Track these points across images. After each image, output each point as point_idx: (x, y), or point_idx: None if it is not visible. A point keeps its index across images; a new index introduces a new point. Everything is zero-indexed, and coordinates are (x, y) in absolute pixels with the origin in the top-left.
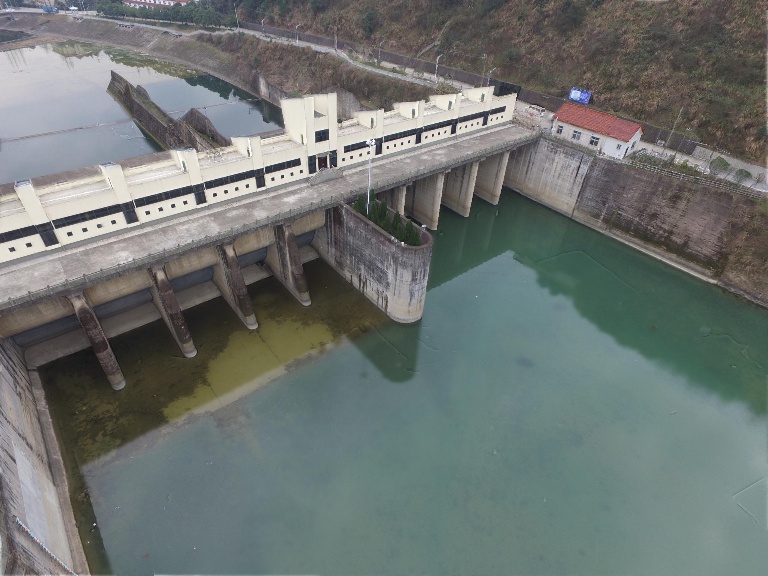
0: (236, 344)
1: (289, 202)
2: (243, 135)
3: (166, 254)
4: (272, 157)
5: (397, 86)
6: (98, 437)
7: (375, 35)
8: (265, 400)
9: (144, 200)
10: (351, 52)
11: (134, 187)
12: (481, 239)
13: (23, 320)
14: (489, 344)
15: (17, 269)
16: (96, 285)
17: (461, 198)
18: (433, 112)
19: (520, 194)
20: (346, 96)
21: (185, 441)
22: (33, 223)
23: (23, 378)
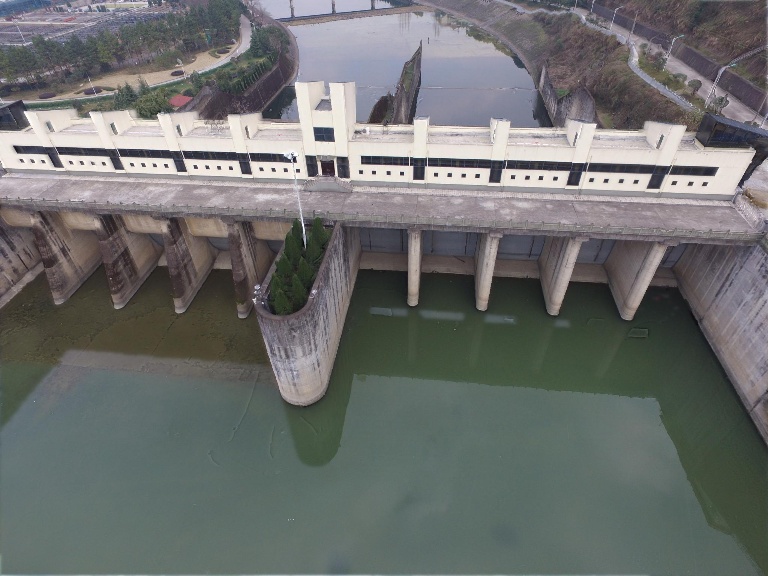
0: (151, 318)
1: (256, 199)
2: (256, 113)
3: (97, 206)
4: (258, 144)
5: (647, 101)
6: (4, 331)
7: (698, 27)
8: (98, 383)
9: (128, 152)
10: (643, 47)
11: (117, 137)
12: (591, 358)
13: (21, 218)
14: (326, 500)
15: (33, 178)
16: (68, 212)
17: (551, 284)
18: (547, 143)
19: (697, 324)
20: (587, 103)
21: (25, 374)
22: (42, 145)
23: (17, 261)
